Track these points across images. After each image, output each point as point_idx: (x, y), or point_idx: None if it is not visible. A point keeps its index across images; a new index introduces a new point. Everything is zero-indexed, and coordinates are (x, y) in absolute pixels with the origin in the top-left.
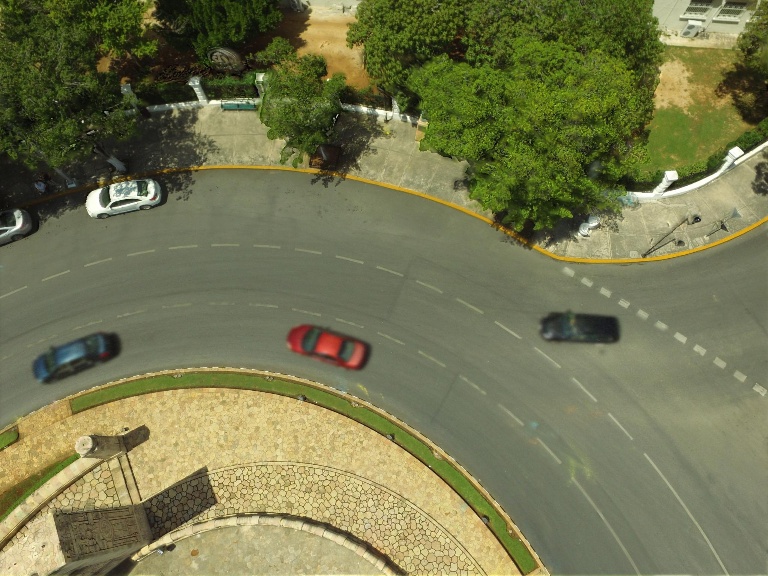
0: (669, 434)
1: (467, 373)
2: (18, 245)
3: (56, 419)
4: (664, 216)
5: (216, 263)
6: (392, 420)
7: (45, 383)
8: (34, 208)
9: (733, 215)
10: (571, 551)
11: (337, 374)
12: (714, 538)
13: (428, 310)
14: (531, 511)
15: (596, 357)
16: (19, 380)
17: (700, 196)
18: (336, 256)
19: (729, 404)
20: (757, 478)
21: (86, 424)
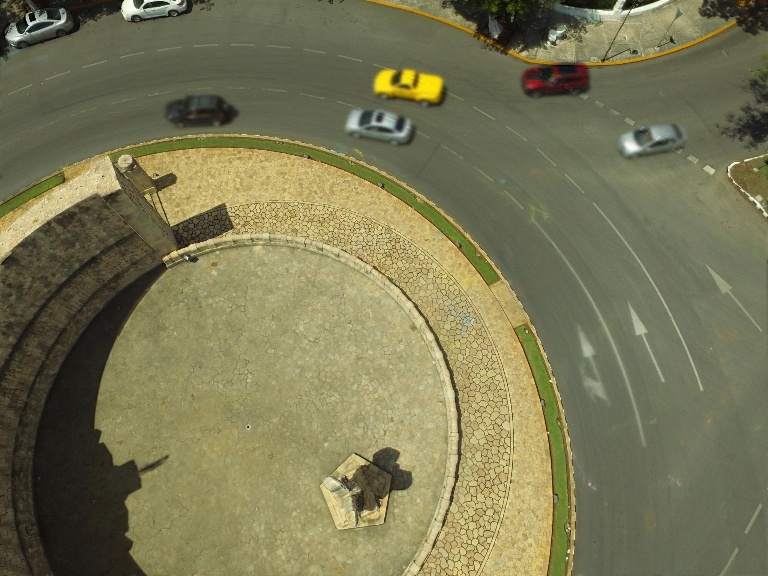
0: (615, 189)
1: (448, 143)
2: (61, 40)
3: None
4: (622, 31)
5: (234, 58)
6: (383, 175)
7: (86, 142)
8: (75, 13)
9: (677, 15)
10: (528, 270)
11: (337, 141)
12: (646, 262)
13: (416, 97)
14: (496, 242)
15: (557, 134)
16: (64, 140)
17: (654, 17)
18: (338, 55)
19: (666, 169)
20: (685, 221)
21: None
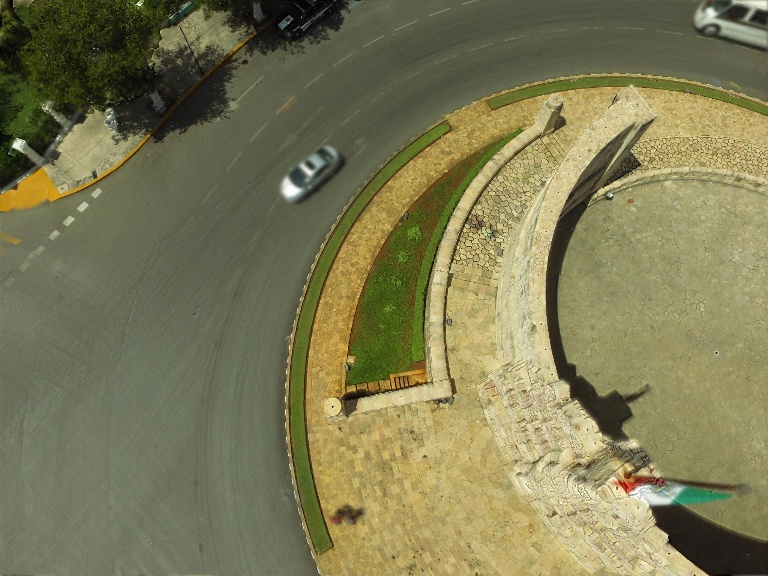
0: None
1: None
2: None
3: (480, 114)
4: None
5: None
6: (767, 106)
7: (459, 90)
8: None
9: None
10: None
11: (710, 76)
12: None
13: None
14: None
15: None
16: (436, 88)
17: None
18: None
19: None
20: None
21: (509, 115)
